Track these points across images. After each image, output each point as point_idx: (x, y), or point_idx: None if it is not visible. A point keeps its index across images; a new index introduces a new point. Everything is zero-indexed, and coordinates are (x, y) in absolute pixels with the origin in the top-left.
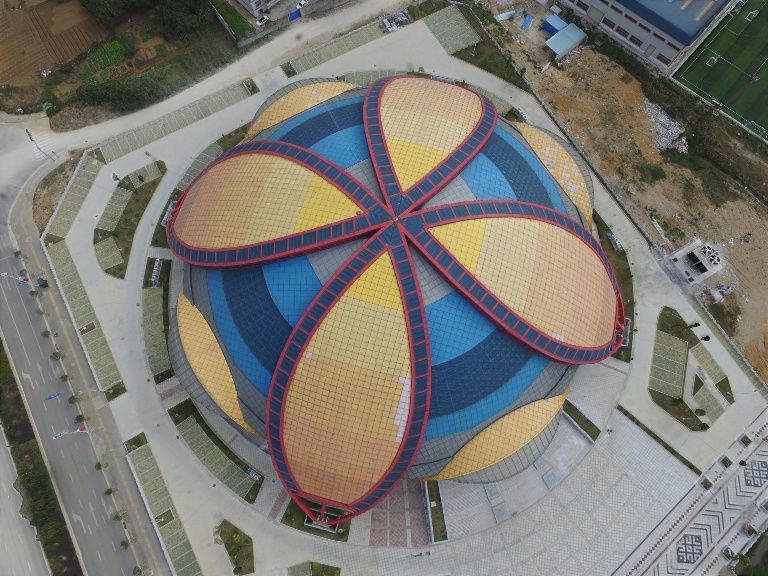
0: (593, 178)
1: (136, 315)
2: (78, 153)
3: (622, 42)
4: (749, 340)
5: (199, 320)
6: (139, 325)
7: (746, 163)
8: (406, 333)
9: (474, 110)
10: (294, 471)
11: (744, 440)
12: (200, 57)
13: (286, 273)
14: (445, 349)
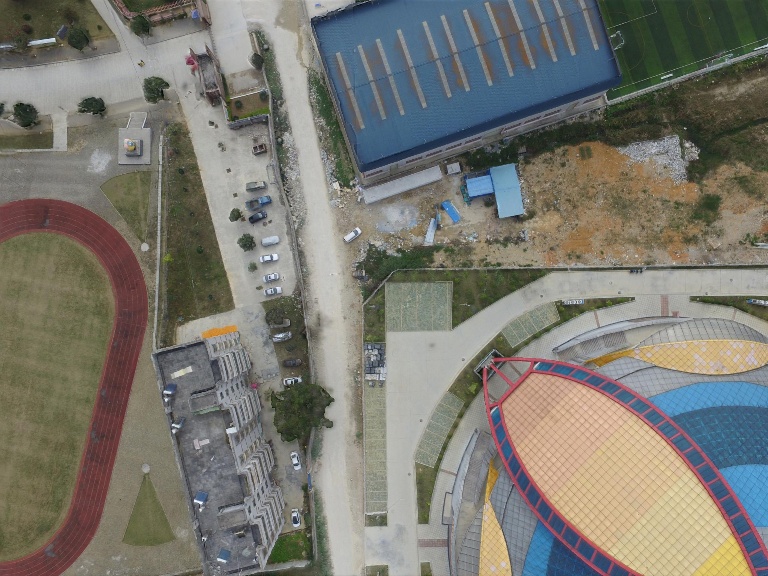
0: (681, 274)
1: None
2: None
3: (540, 126)
4: None
5: None
6: None
7: (747, 100)
8: None
9: (643, 434)
10: None
11: None
12: None
13: None
14: None
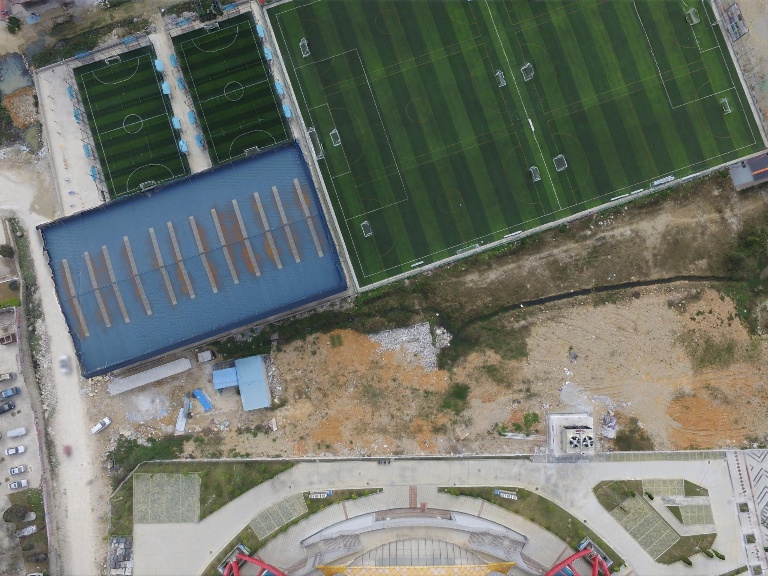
0: (429, 464)
1: None
2: None
3: (289, 316)
4: (664, 432)
5: None
6: None
7: (497, 287)
8: None
9: None
10: None
11: (743, 510)
12: None
13: None
14: None
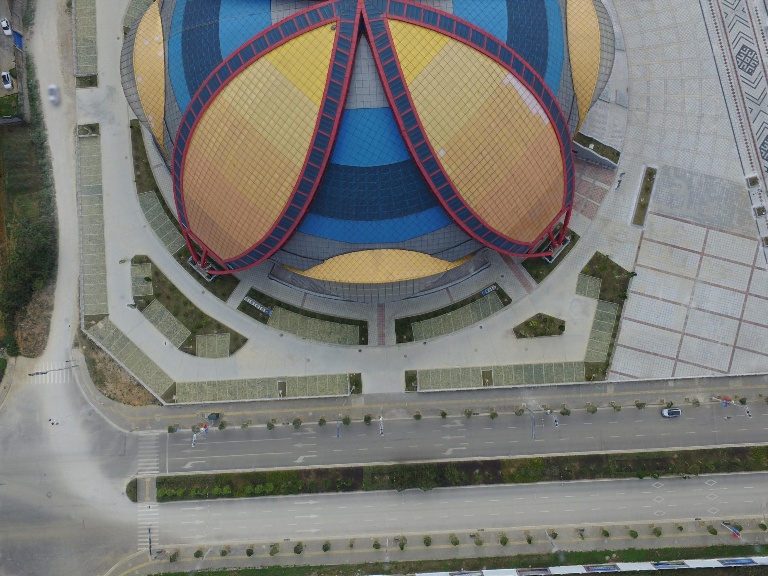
0: None
1: (291, 340)
2: (80, 339)
3: None
4: None
5: (343, 260)
6: (302, 341)
7: None
8: (471, 49)
9: None
10: (516, 237)
11: None
12: (21, 169)
13: (352, 139)
14: (497, 31)
